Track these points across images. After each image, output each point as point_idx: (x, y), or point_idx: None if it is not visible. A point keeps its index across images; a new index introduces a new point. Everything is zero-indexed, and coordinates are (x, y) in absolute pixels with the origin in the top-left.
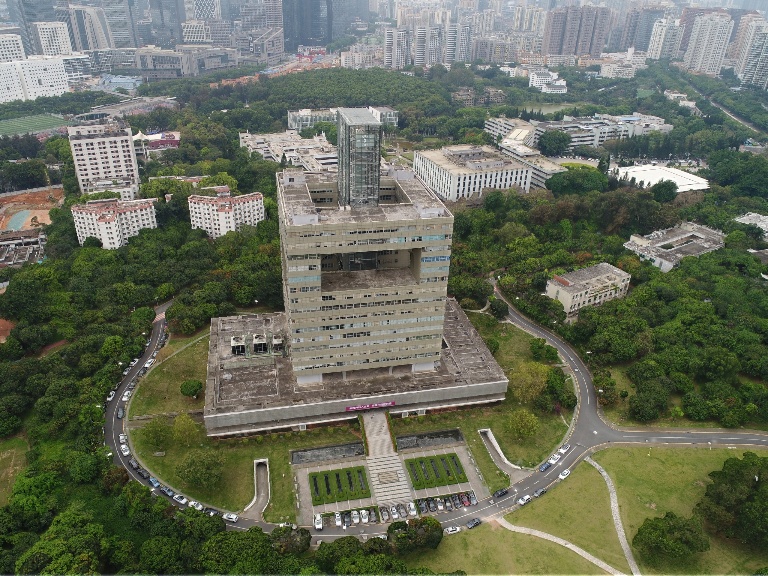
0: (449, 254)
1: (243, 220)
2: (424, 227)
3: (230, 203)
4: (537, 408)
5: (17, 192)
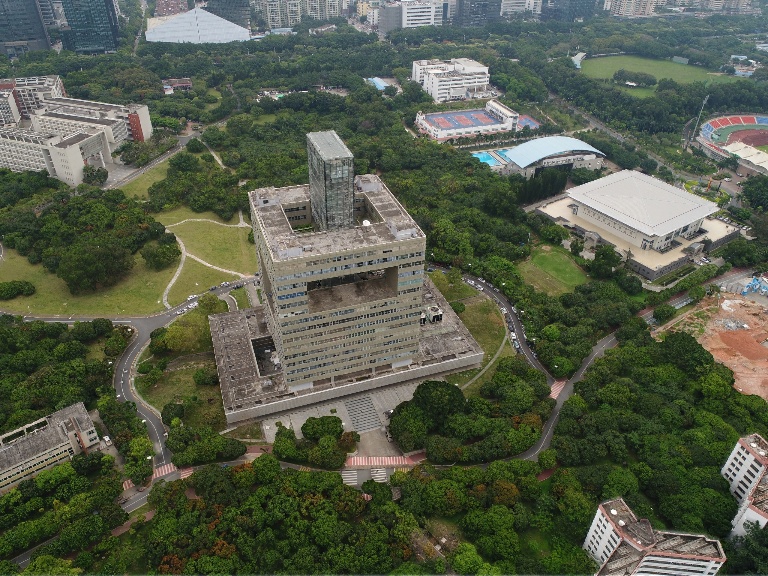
0: None
1: None
2: None
3: None
4: None
5: None
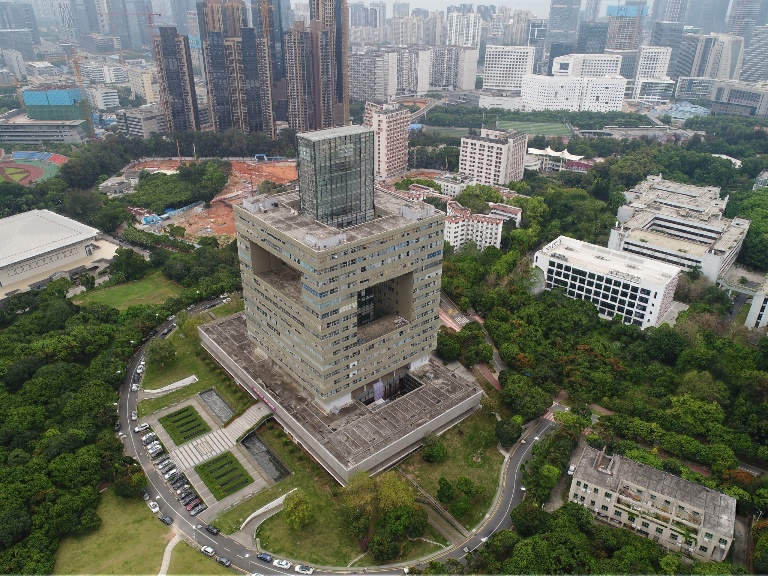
0: (319, 291)
1: (474, 238)
2: (300, 251)
3: (464, 217)
4: (344, 519)
5: (439, 171)
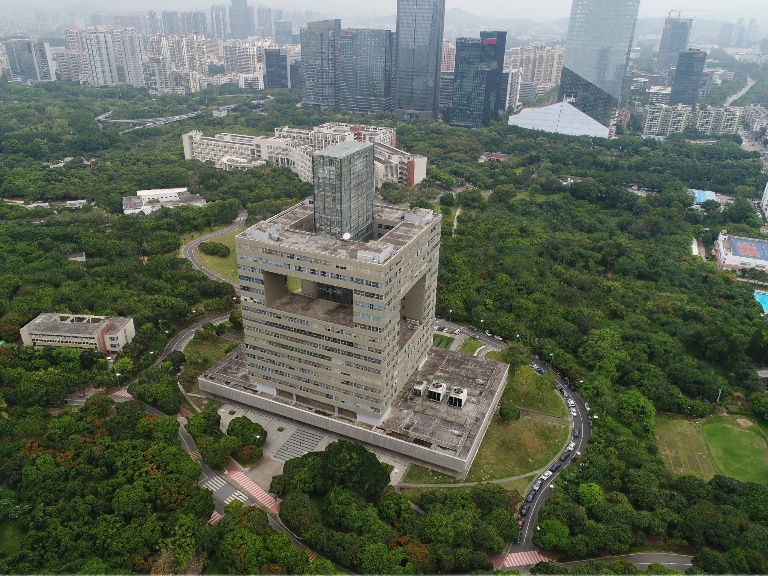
0: None
1: None
2: None
3: None
4: None
5: None
